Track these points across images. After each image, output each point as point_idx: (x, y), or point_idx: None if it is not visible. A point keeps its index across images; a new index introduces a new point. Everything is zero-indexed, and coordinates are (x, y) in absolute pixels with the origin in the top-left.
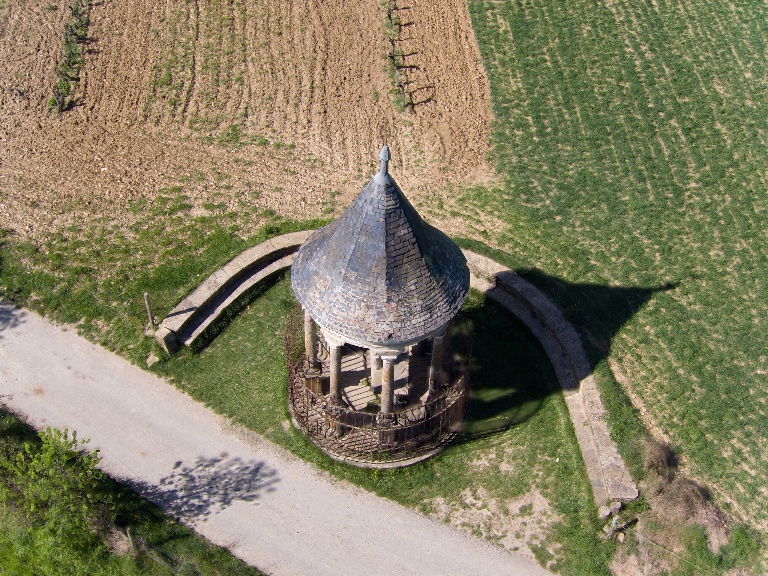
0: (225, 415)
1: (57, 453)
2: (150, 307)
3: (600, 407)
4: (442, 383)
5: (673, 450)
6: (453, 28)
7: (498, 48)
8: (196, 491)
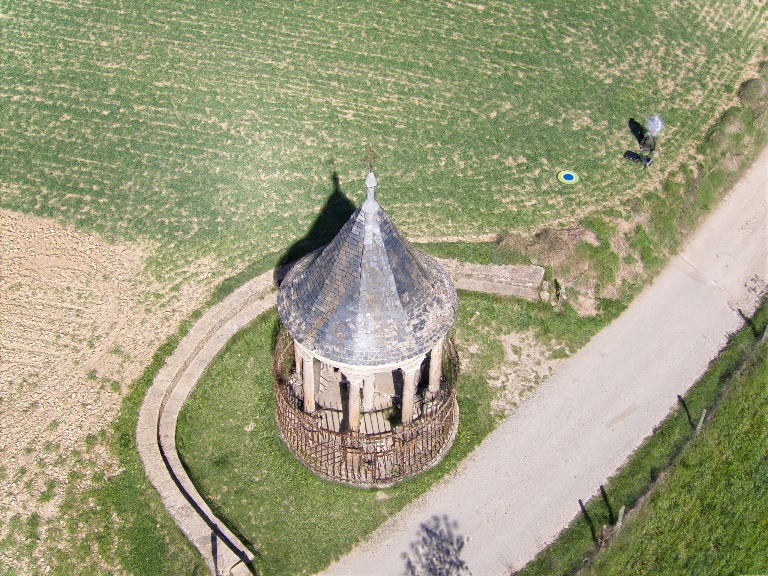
0: (354, 545)
1: None
2: (214, 567)
3: (451, 261)
4: None
5: (505, 235)
6: None
7: None
8: None
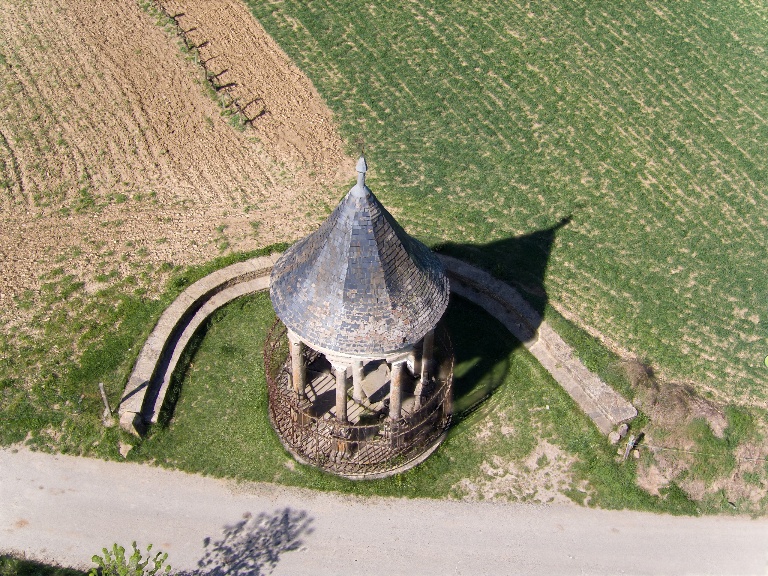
0: (227, 477)
1: (128, 570)
2: (107, 396)
3: (566, 347)
4: (417, 374)
5: (644, 363)
6: (249, 37)
7: (301, 46)
8: (239, 560)
